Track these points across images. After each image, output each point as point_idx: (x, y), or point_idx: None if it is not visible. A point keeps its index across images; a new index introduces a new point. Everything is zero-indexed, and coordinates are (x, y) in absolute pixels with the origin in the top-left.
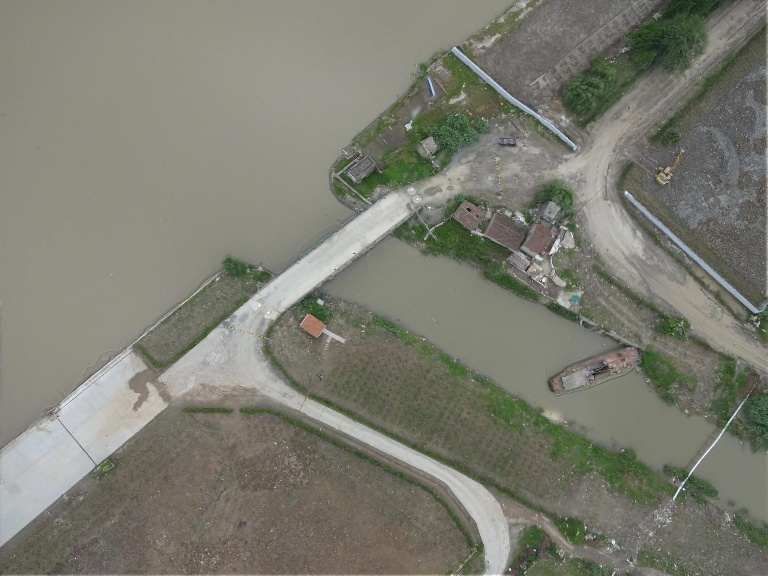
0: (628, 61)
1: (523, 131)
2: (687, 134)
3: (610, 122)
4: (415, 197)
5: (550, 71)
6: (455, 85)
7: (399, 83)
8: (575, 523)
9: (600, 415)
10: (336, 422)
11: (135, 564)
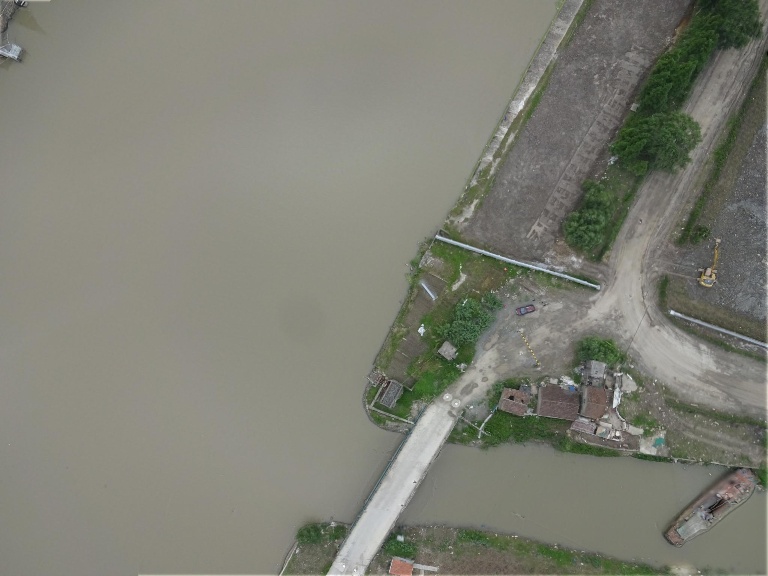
0: (621, 172)
1: (537, 291)
2: (716, 221)
3: (626, 244)
4: (453, 402)
5: (542, 214)
6: (452, 270)
7: (397, 289)
8: None
9: (735, 552)
10: None
11: None
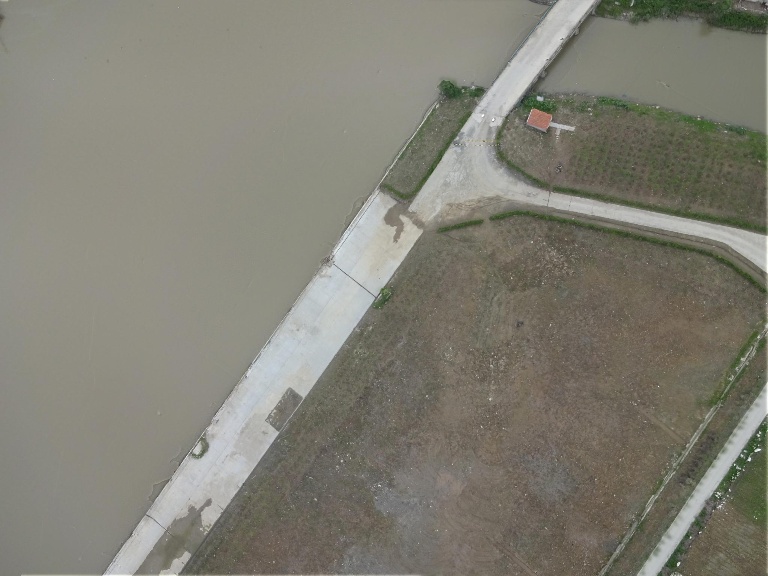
0: None
1: None
2: None
3: None
4: None
5: None
6: None
7: None
8: None
9: None
10: (587, 208)
11: (431, 377)
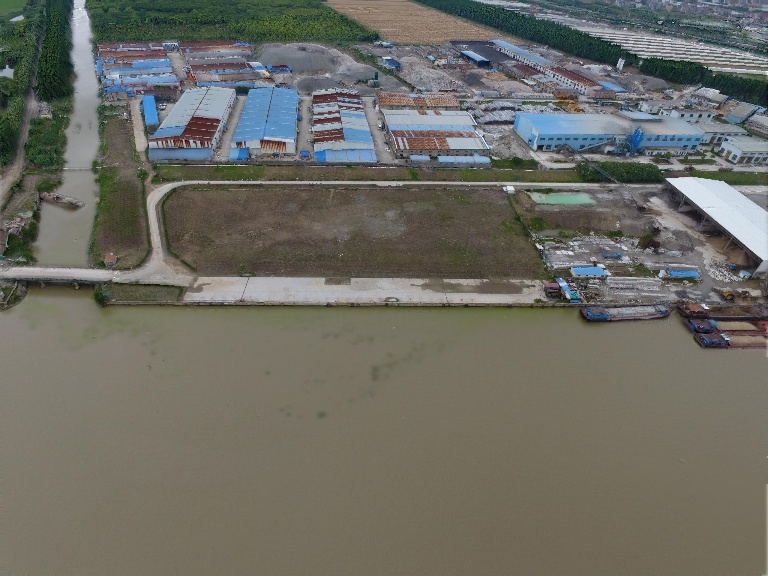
0: None
1: None
2: None
3: None
4: None
5: None
6: None
7: None
8: (139, 175)
9: (85, 193)
10: (156, 237)
11: (275, 246)
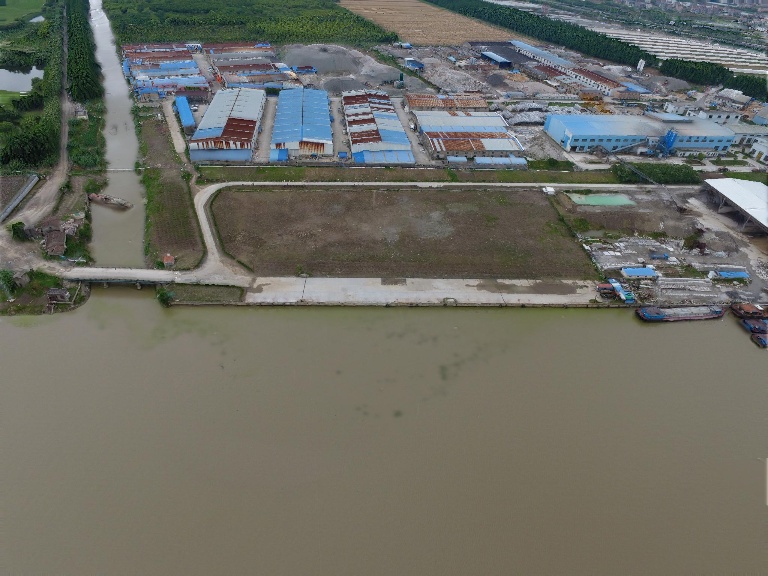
0: None
1: None
2: None
3: None
4: (61, 271)
5: None
6: None
7: None
8: (183, 176)
9: (132, 194)
10: (209, 238)
11: (327, 247)
